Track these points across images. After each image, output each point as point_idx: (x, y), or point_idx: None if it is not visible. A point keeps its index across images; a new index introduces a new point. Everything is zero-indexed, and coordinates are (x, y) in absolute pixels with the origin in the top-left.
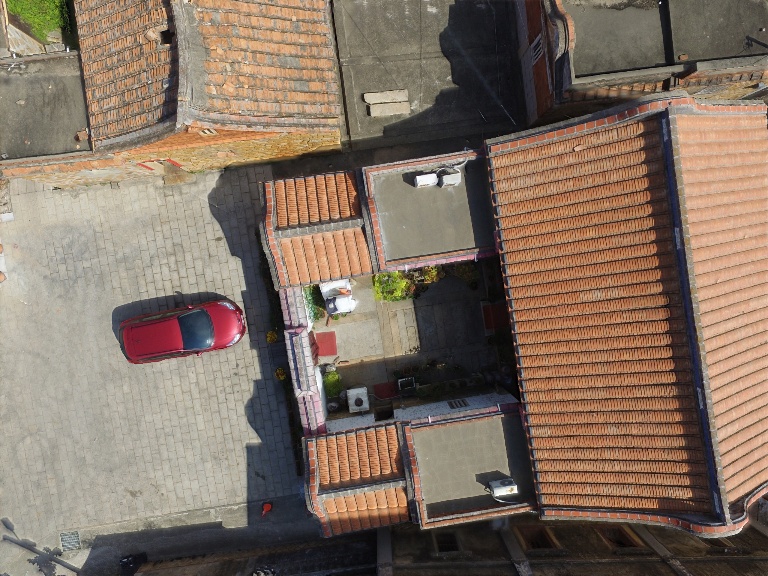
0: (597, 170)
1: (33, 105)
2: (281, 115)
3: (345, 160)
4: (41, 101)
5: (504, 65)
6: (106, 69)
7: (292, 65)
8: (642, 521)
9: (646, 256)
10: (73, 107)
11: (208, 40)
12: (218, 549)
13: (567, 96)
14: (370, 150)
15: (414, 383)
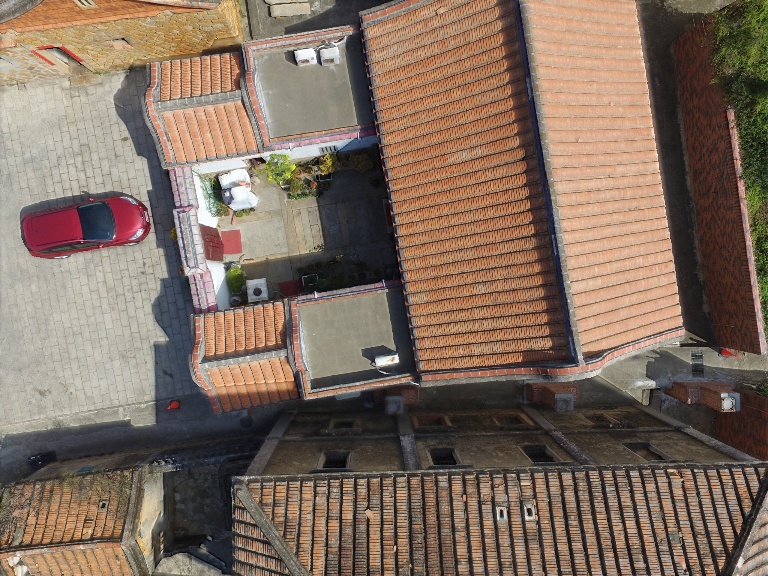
0: (458, 31)
1: None
2: None
3: None
4: None
5: None
6: None
7: None
8: (510, 377)
9: (504, 112)
10: None
11: None
12: (127, 447)
13: None
14: None
15: (318, 279)
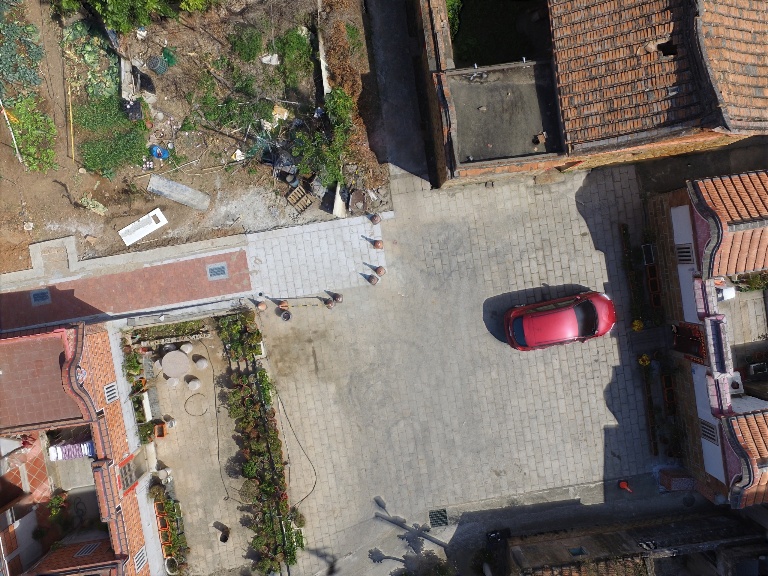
0: None
1: (493, 111)
2: (748, 119)
3: (703, 160)
4: (500, 107)
5: None
6: (588, 78)
7: (753, 73)
8: None
9: None
10: (529, 113)
11: None
12: (576, 524)
13: None
14: (727, 150)
15: (766, 368)
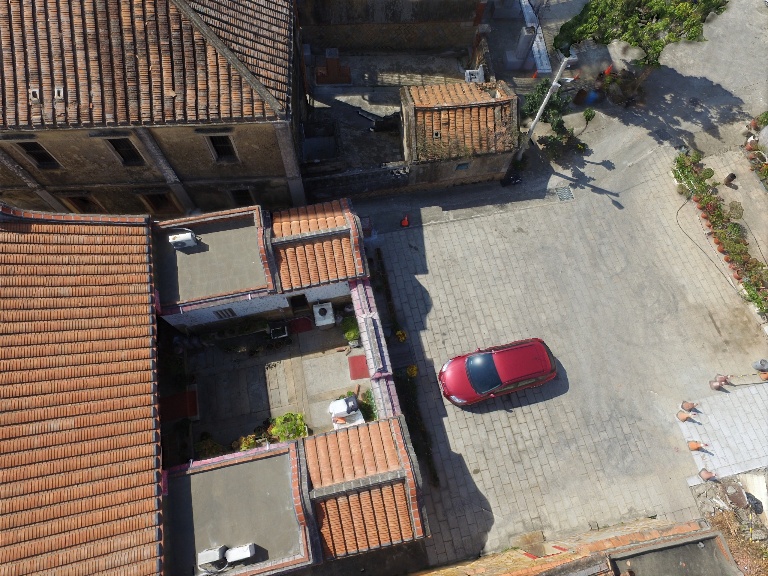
0: None
1: None
2: None
3: None
4: None
5: None
6: None
7: None
8: (51, 214)
9: None
10: None
11: None
12: (443, 191)
13: None
14: None
15: (272, 333)
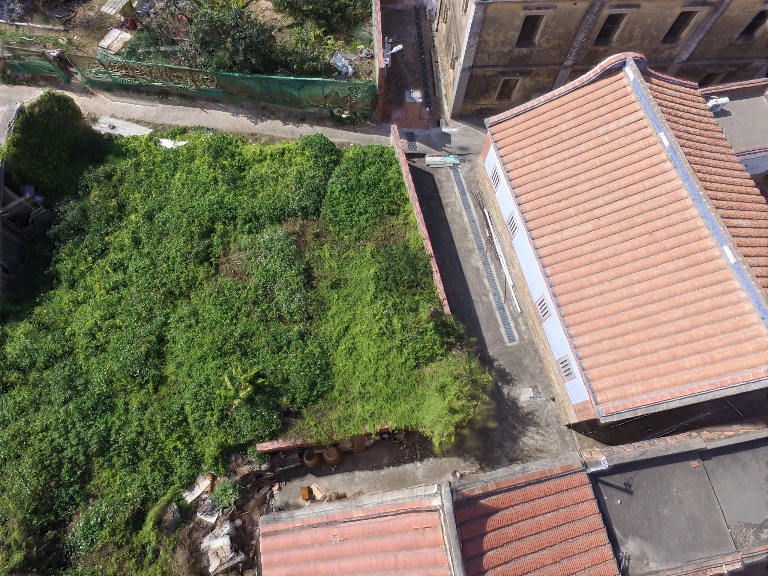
0: None
1: None
2: None
3: None
4: None
5: None
6: None
7: None
8: None
9: None
10: None
11: None
12: None
13: None
14: None
15: None
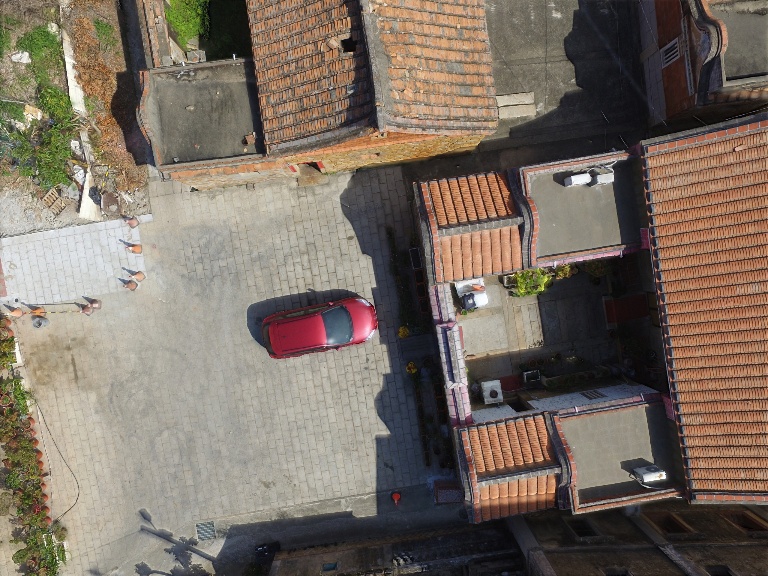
0: (758, 169)
1: (201, 110)
2: (449, 118)
3: (472, 161)
4: (209, 107)
5: (626, 68)
6: (282, 76)
7: (458, 71)
8: None
9: None
10: (240, 112)
11: (389, 48)
12: (348, 537)
13: (712, 98)
14: (496, 151)
15: (539, 376)
